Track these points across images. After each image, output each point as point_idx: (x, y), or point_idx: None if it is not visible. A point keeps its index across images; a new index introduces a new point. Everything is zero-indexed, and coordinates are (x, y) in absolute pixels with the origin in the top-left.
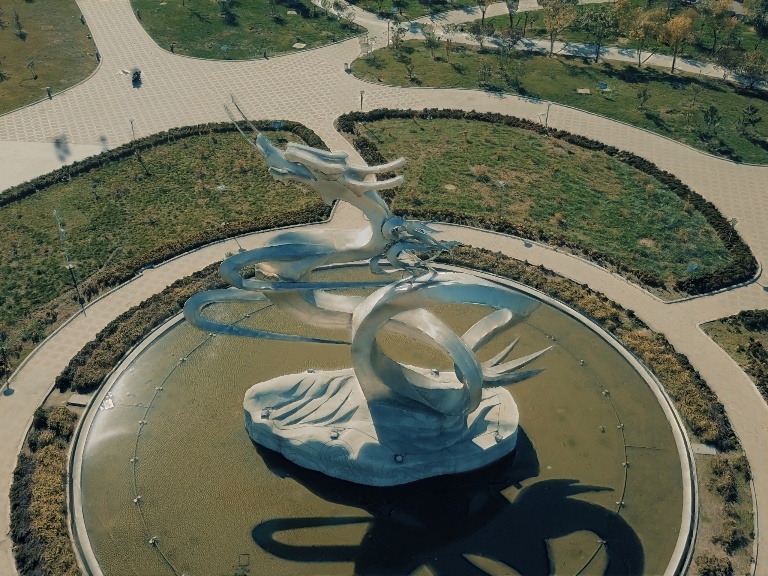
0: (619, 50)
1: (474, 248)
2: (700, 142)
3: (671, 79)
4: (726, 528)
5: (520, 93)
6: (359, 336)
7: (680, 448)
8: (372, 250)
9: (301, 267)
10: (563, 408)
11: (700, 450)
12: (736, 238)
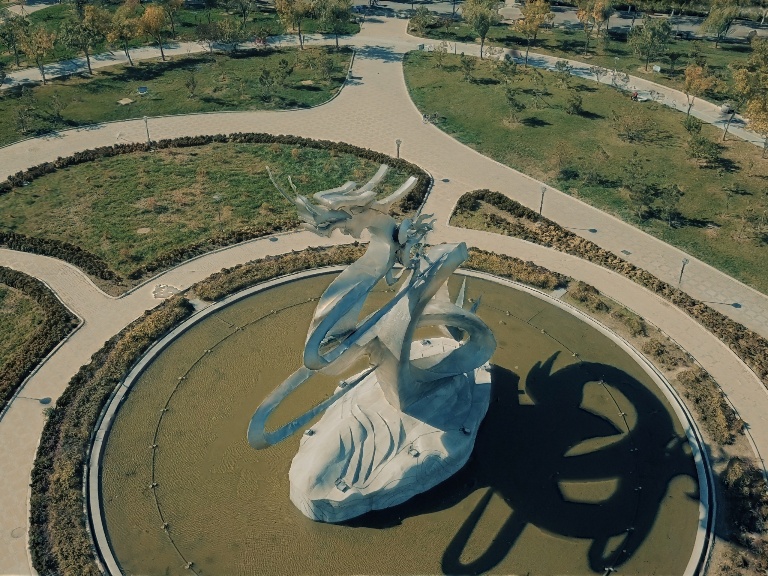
0: (94, 57)
1: (247, 264)
2: (267, 104)
3: (175, 65)
4: (630, 324)
5: (72, 126)
6: (404, 349)
7: (551, 301)
8: (390, 263)
9: (357, 313)
10: None
11: (558, 295)
12: (389, 158)
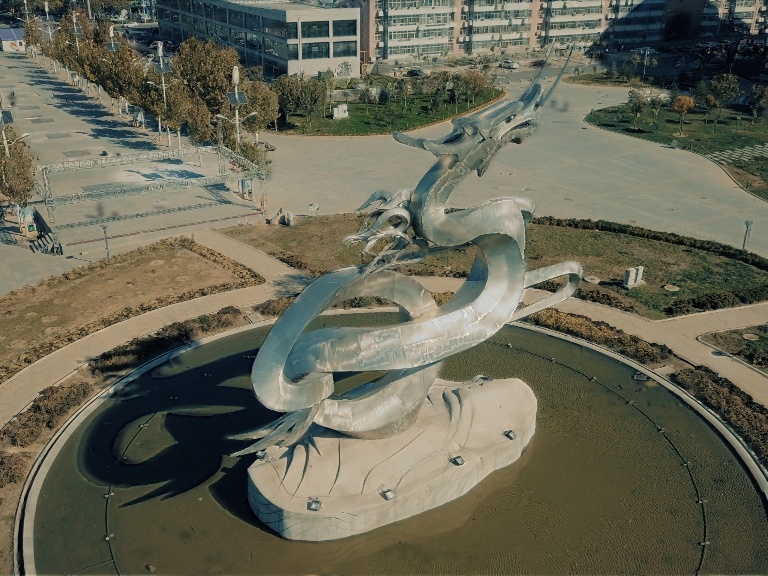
0: None
1: None
2: None
3: None
4: None
5: None
6: None
7: None
8: None
9: None
10: (214, 573)
11: None
12: None
